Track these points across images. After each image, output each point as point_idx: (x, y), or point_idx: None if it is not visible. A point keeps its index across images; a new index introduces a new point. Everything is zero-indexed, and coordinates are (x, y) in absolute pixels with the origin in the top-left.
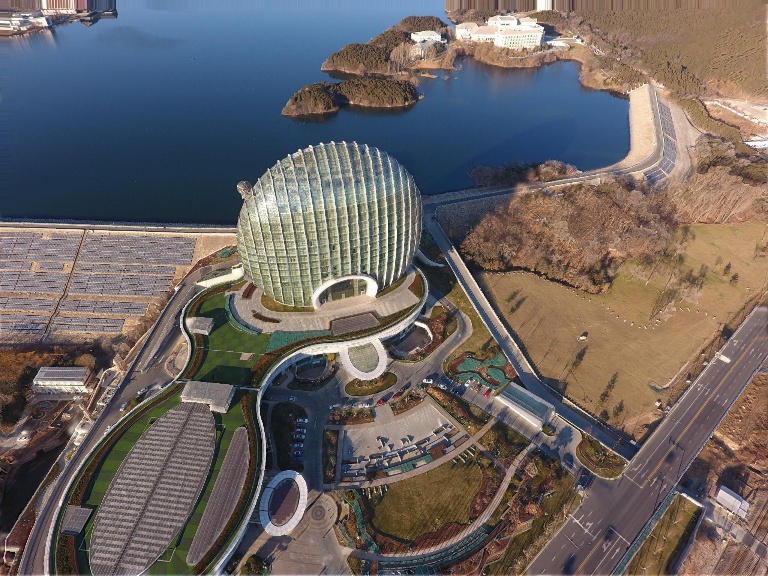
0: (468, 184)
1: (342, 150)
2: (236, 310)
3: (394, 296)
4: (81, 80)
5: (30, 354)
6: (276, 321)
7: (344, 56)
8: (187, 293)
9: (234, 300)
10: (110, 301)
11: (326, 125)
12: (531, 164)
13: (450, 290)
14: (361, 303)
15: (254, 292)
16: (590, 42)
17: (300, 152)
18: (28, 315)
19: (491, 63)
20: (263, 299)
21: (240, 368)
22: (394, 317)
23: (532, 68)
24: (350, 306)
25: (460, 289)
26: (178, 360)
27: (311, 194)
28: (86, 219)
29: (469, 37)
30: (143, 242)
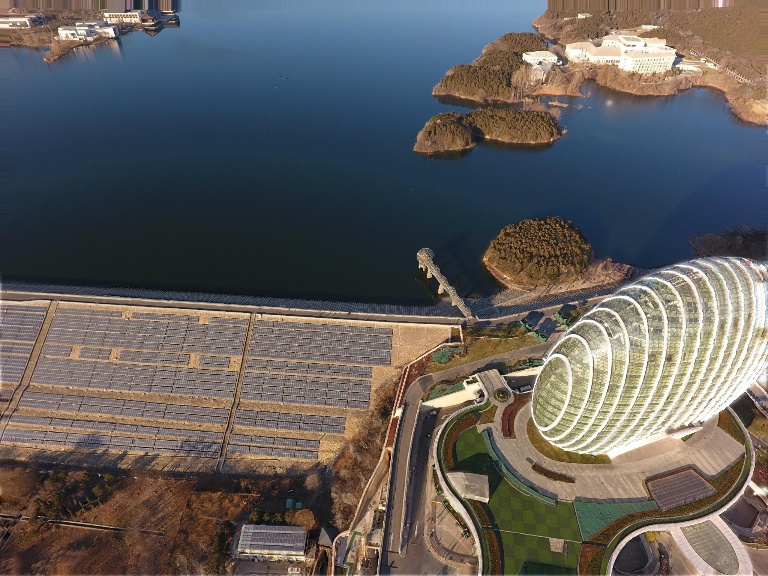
0: (677, 251)
1: (742, 275)
2: (505, 457)
3: (706, 439)
4: (186, 107)
5: (217, 497)
6: (570, 480)
7: (459, 80)
8: (416, 419)
9: (495, 439)
10: (296, 413)
11: (459, 162)
12: (759, 229)
13: (751, 420)
14: (668, 450)
15: (515, 426)
16: (724, 66)
17: (685, 278)
18: (195, 430)
19: (620, 89)
20: (532, 439)
21: (560, 568)
22: (729, 478)
23: (667, 96)
24: (656, 455)
25: (765, 419)
26: (440, 532)
27: (700, 339)
28: (240, 293)
29: (587, 58)
30: (326, 332)
